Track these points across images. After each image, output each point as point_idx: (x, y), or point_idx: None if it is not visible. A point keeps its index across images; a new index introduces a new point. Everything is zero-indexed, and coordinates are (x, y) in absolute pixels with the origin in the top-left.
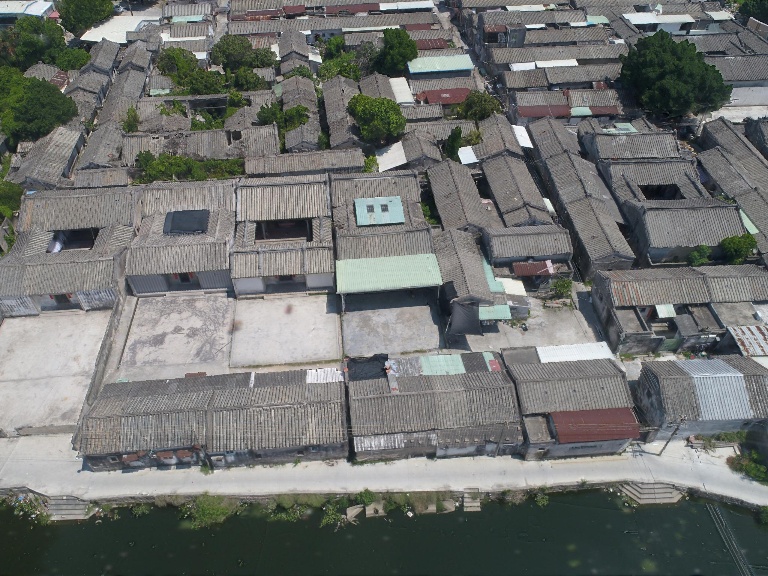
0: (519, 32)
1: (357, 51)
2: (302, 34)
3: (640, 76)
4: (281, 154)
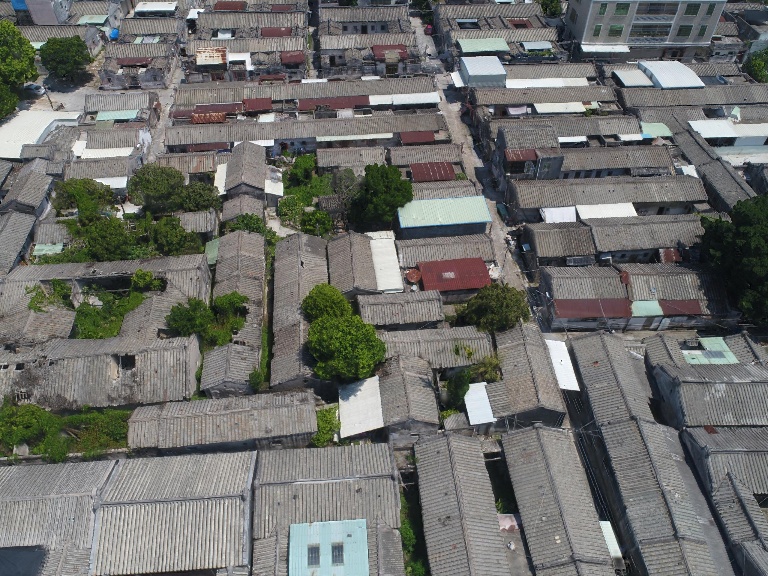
0: (554, 161)
1: (333, 174)
2: (261, 148)
3: (739, 267)
4: (189, 405)
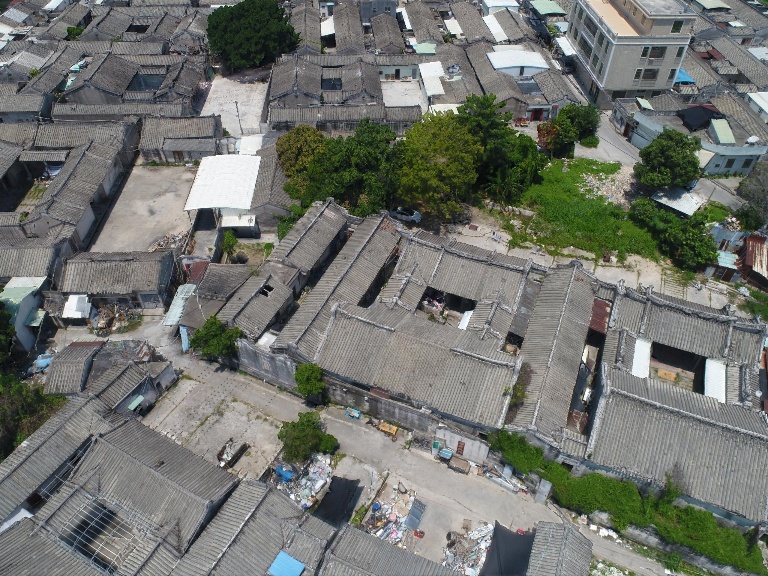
0: None
1: None
2: None
3: None
4: None
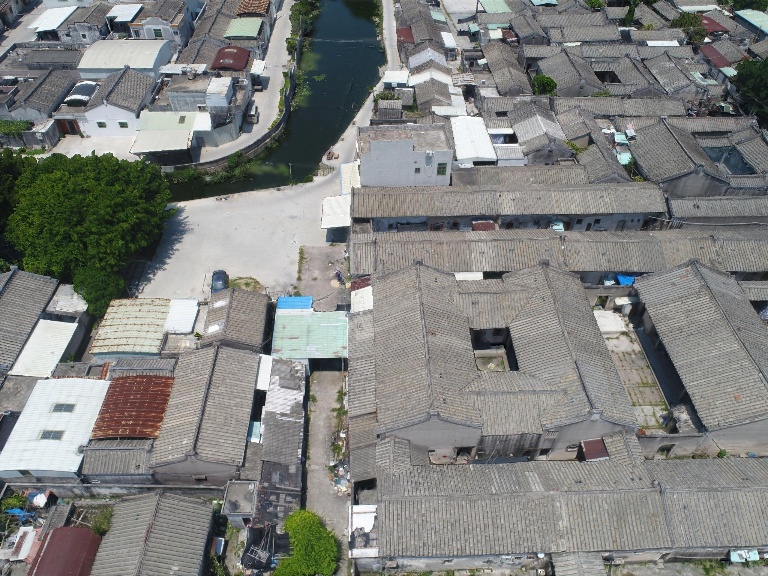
0: None
1: None
2: None
3: None
4: None
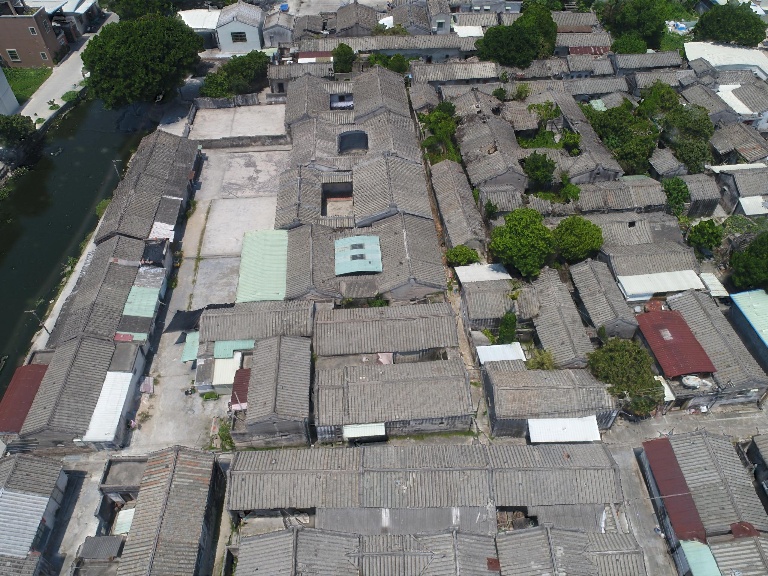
0: None
1: None
2: None
3: None
4: (463, 183)
